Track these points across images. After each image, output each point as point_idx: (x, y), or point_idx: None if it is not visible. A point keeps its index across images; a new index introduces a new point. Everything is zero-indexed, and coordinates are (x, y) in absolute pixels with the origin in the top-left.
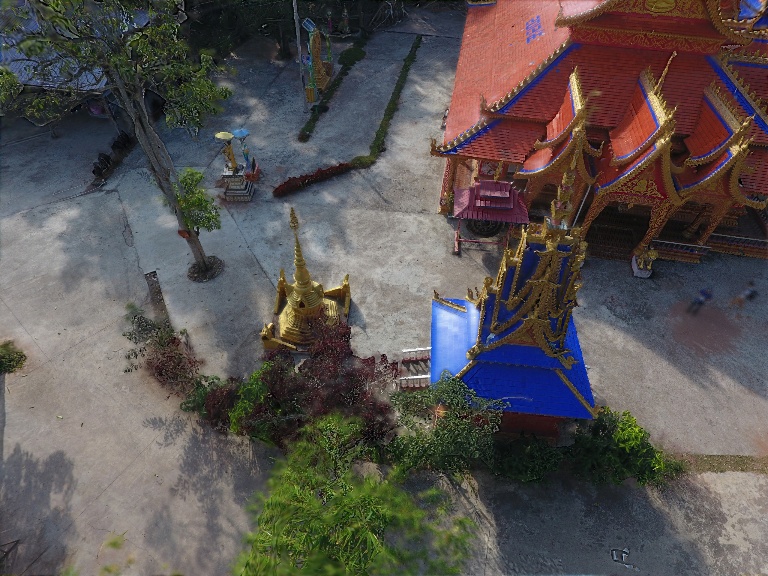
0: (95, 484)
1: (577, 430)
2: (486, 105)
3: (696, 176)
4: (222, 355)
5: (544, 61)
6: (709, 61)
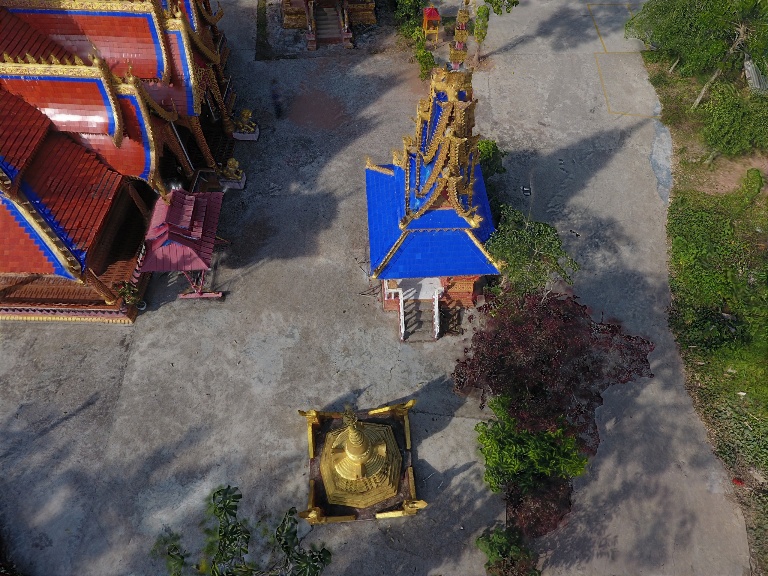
0: None
1: None
2: None
3: None
4: None
5: None
6: None
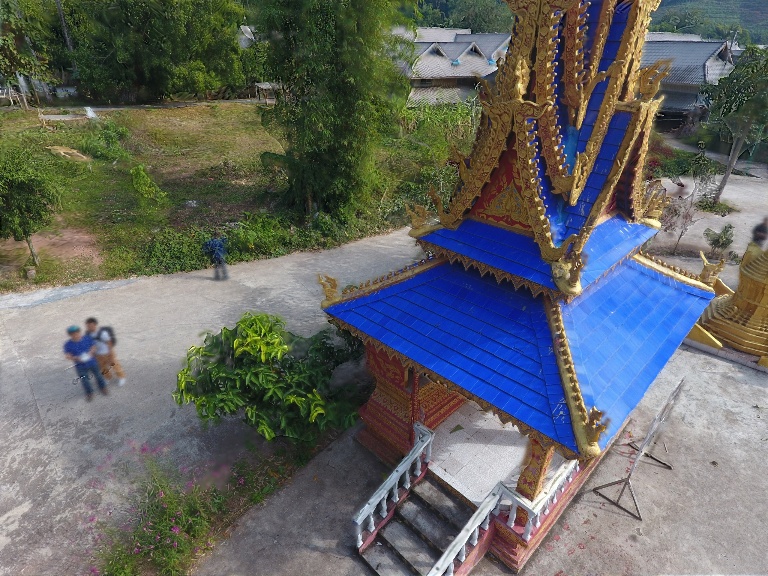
0: None
1: None
2: None
3: None
4: None
5: None
6: None
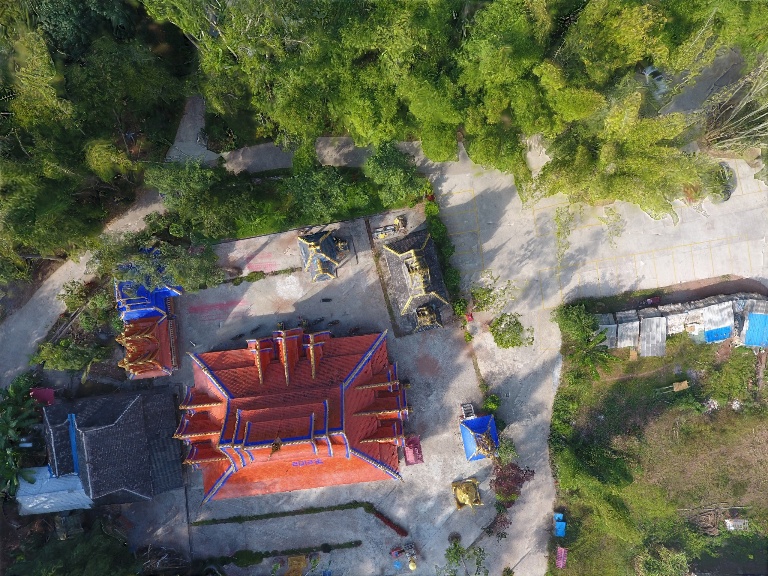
0: (529, 522)
1: None
2: None
3: None
4: (485, 513)
5: None
6: None
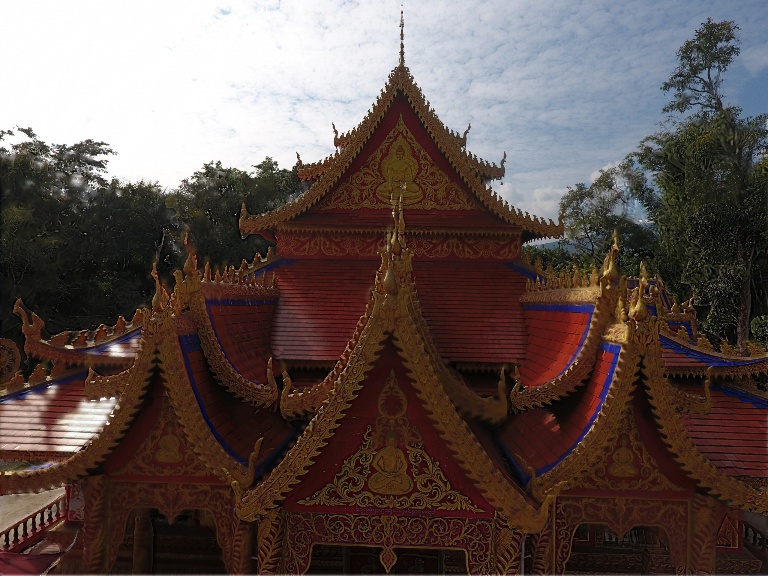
0: None
1: None
2: None
3: (561, 436)
4: None
5: None
6: (513, 268)
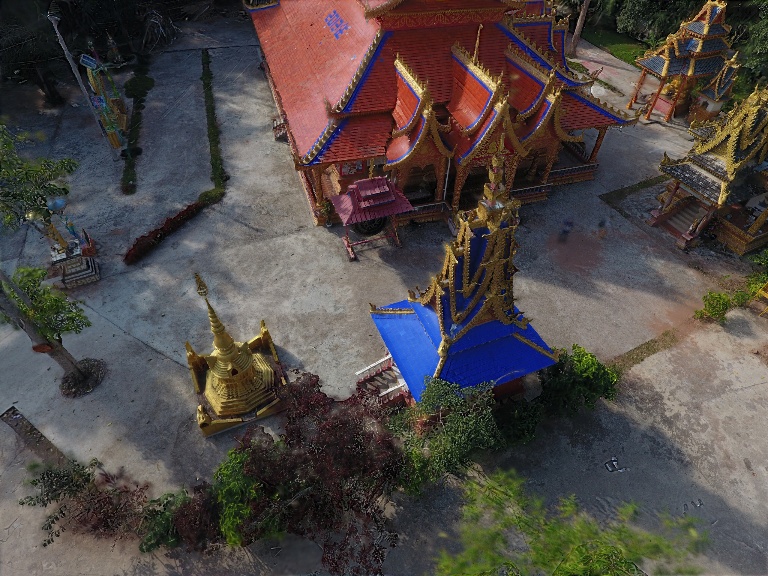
0: None
1: (539, 378)
2: (331, 108)
3: (528, 128)
4: (157, 466)
5: (367, 53)
6: (499, 27)
